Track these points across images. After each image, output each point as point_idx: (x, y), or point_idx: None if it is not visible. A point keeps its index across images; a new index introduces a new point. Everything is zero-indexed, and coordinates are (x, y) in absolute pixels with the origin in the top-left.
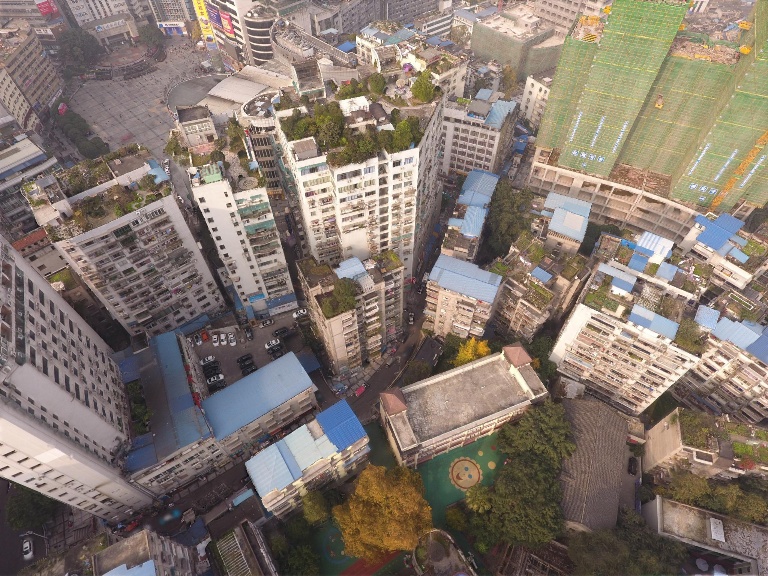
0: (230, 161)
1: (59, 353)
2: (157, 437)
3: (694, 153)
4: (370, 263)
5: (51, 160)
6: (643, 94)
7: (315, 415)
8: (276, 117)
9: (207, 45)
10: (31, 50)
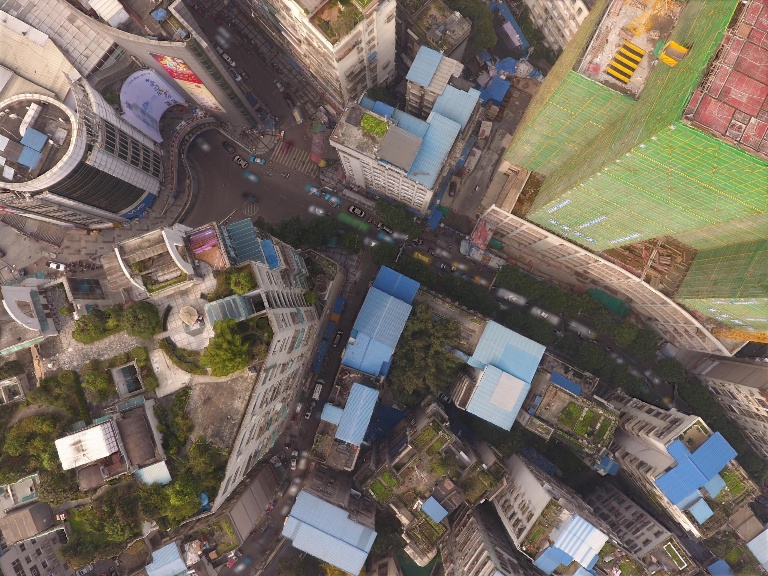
0: None
1: None
2: None
3: (731, 291)
4: (193, 552)
5: None
6: (678, 227)
7: None
8: None
9: None
10: None
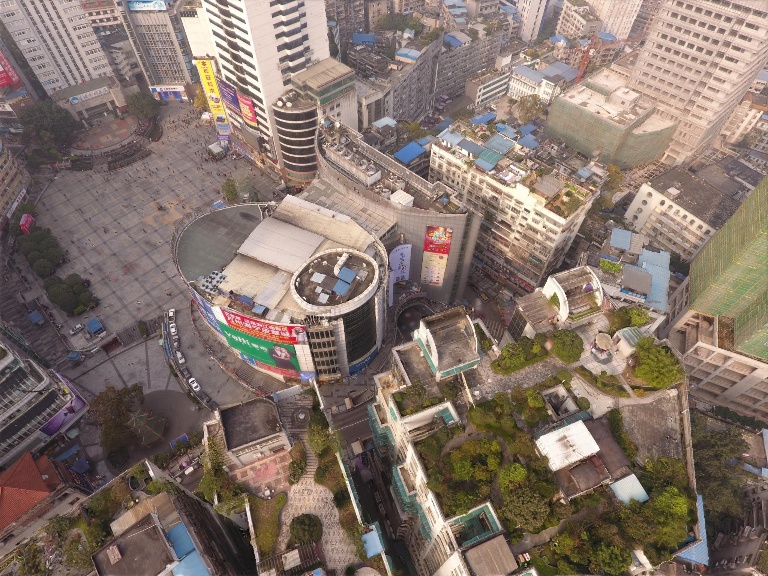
0: (320, 512)
1: None
2: None
3: None
4: None
5: (4, 361)
6: None
7: None
8: (399, 423)
9: (217, 126)
10: None
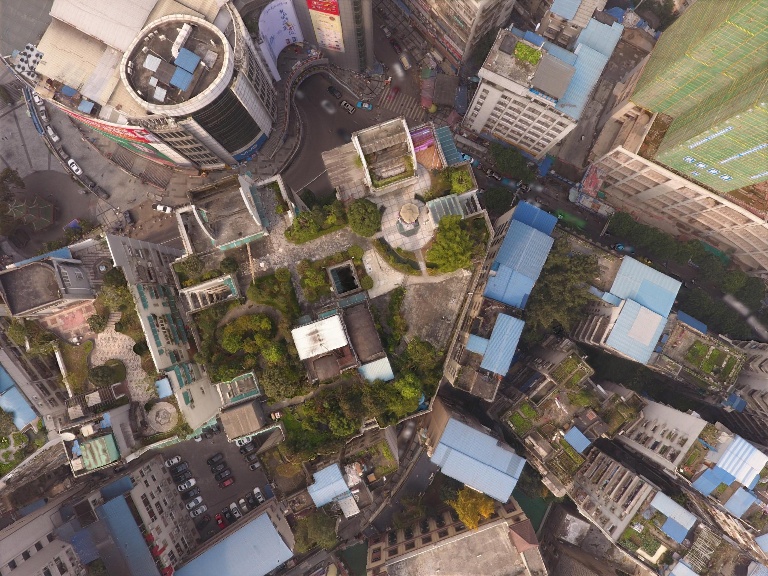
0: (125, 357)
1: None
2: None
3: None
4: (354, 474)
5: None
6: None
7: None
8: None
9: None
10: None
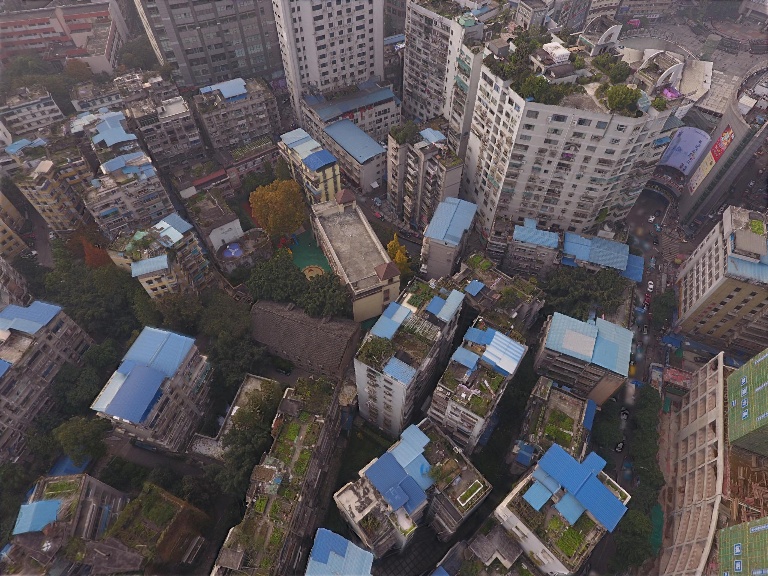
0: None
1: (334, 18)
2: (323, 103)
3: None
4: (442, 146)
5: None
6: None
7: (358, 194)
8: None
9: None
10: None
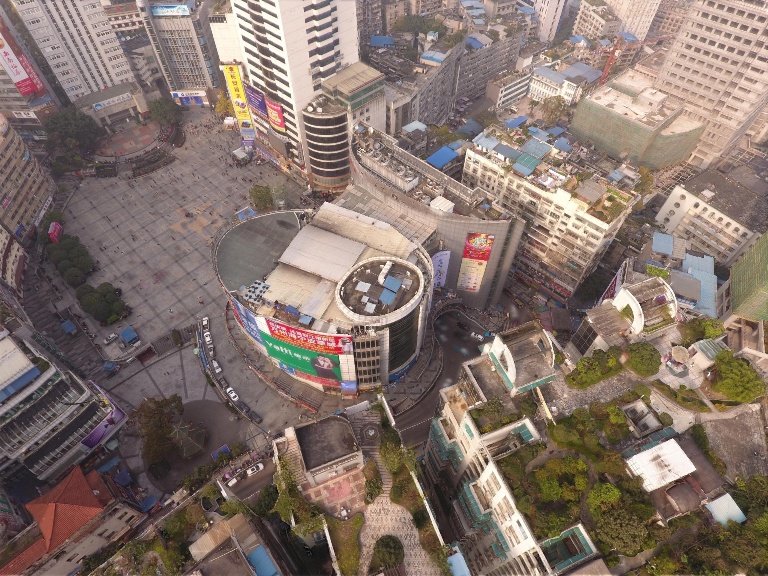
0: (399, 532)
1: None
2: None
3: None
4: None
5: (46, 373)
6: None
7: None
8: (477, 440)
9: (242, 131)
10: (9, 156)
